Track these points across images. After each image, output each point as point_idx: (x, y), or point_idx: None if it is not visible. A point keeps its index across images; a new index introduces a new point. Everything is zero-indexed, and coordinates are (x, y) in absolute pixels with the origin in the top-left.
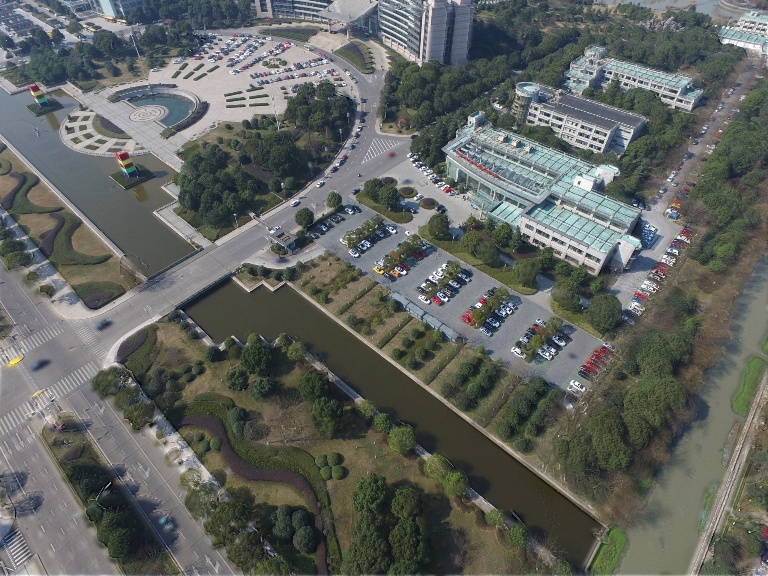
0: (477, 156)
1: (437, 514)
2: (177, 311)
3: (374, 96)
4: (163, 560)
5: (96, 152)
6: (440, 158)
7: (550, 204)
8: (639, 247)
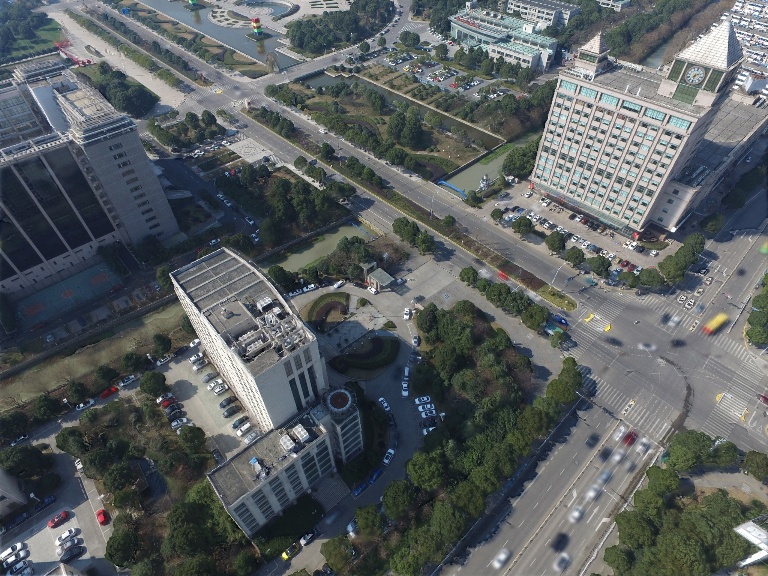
0: (469, 21)
1: (427, 134)
2: (298, 79)
3: (408, 4)
4: None
5: (234, 26)
6: (448, 30)
7: (508, 41)
8: (551, 53)
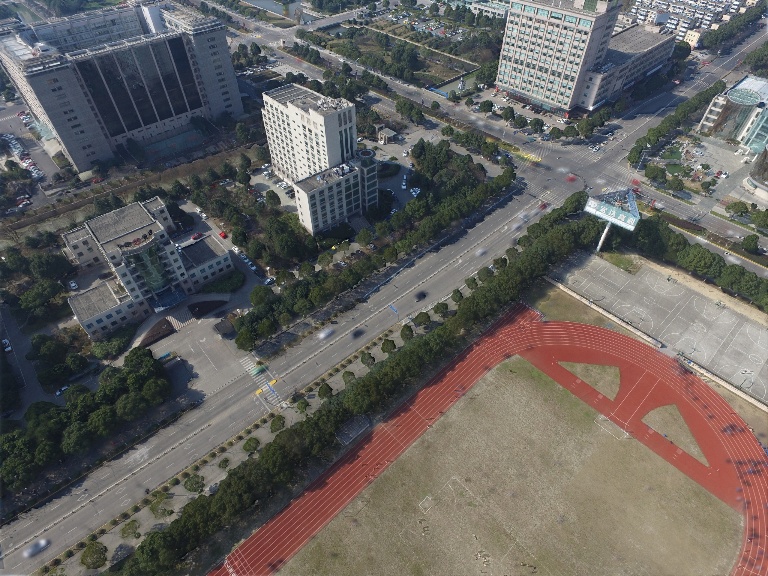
0: None
1: (421, 62)
2: None
3: None
4: None
5: None
6: None
7: (487, 2)
8: None
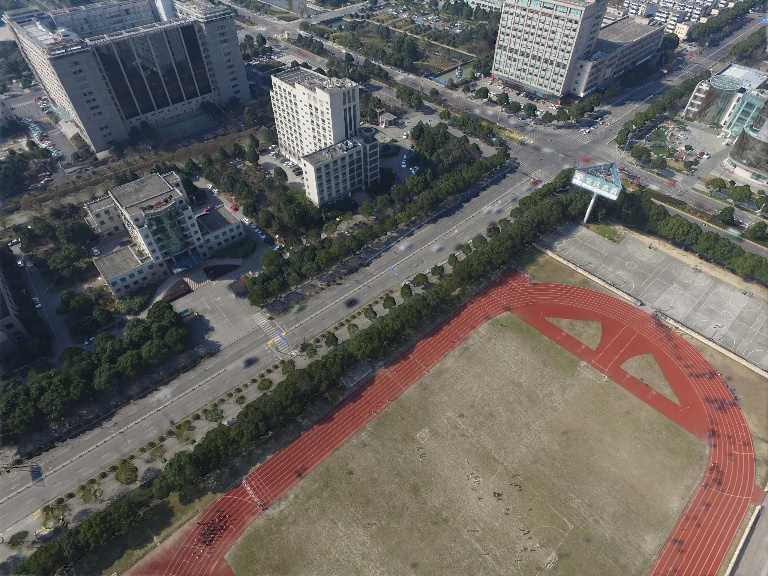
0: None
1: (421, 53)
2: None
3: None
4: None
5: None
6: None
7: None
8: None
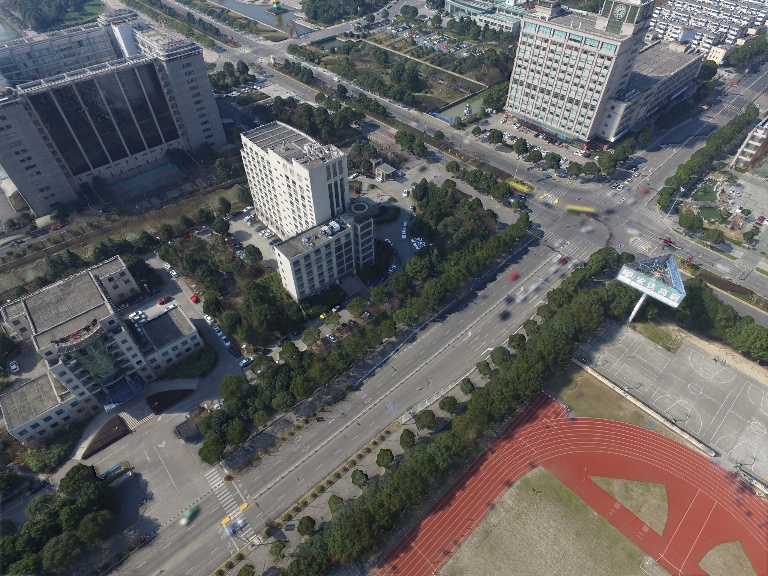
0: None
1: None
2: None
3: None
4: None
5: (255, 3)
6: (442, 6)
7: (493, 13)
8: None
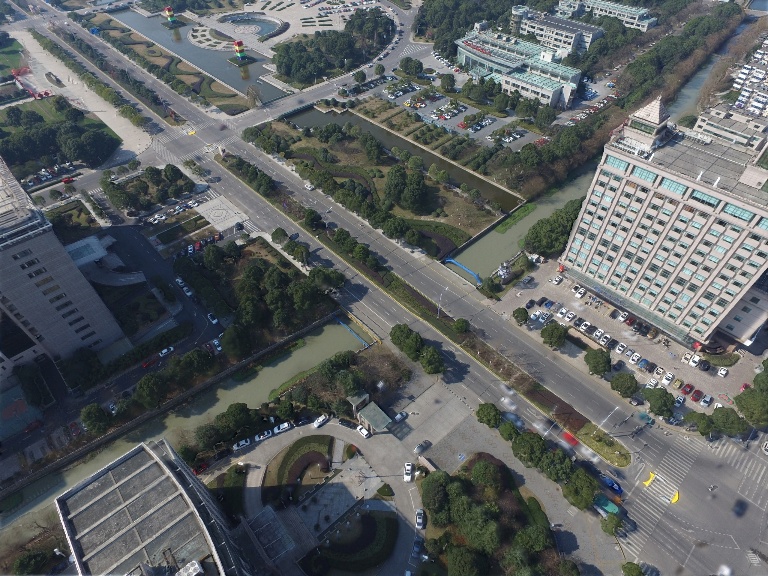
0: (478, 46)
1: (432, 191)
2: (282, 116)
3: (410, 22)
4: (288, 199)
5: (215, 48)
6: (454, 54)
7: (523, 71)
8: (575, 88)
